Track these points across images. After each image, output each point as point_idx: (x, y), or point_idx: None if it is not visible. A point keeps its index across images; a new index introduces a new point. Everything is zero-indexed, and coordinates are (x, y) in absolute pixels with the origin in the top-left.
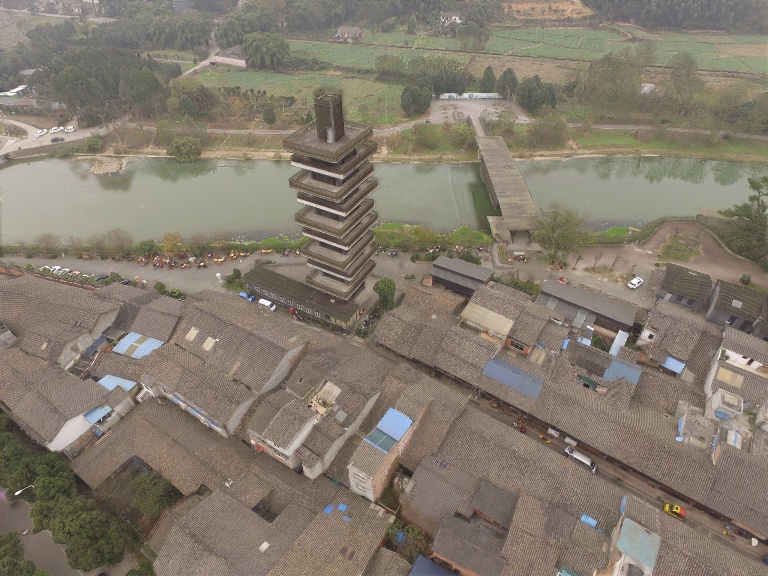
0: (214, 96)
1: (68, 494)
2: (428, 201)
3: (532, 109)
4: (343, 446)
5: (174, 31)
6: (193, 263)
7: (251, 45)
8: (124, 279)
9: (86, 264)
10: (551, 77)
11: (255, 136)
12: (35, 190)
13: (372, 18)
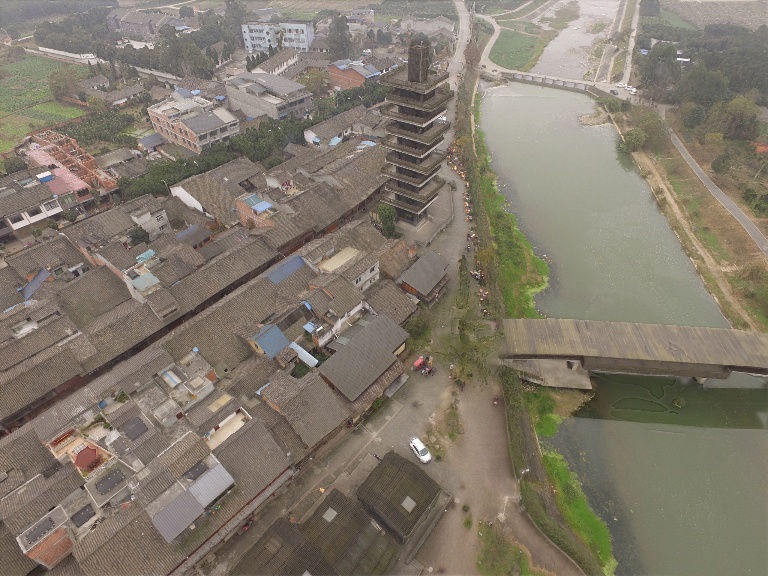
0: (752, 131)
1: (279, 141)
2: (607, 300)
3: None
4: (272, 208)
5: None
6: (453, 160)
7: None
8: None
9: None
10: None
11: (688, 171)
12: (546, 105)
13: None
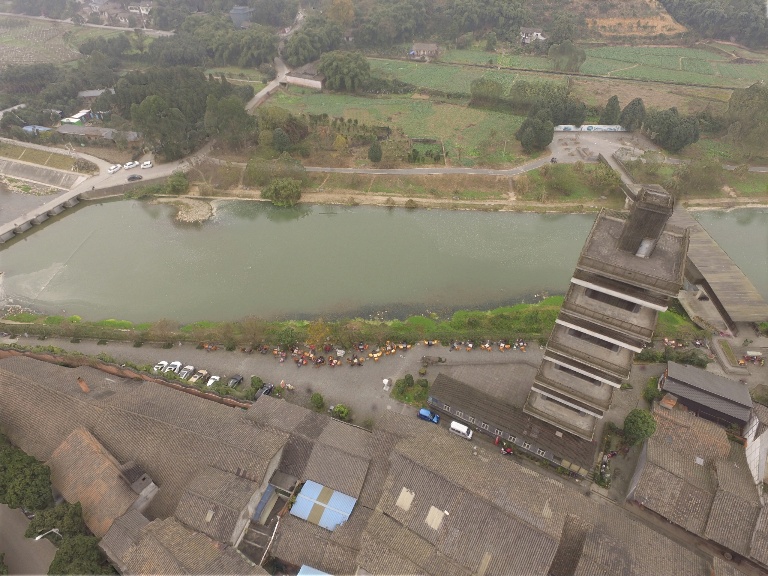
0: (303, 126)
1: None
2: None
3: (670, 146)
4: None
5: (238, 47)
6: (343, 358)
7: (330, 65)
8: (265, 384)
9: (210, 357)
10: (669, 105)
11: (359, 176)
12: (119, 242)
13: (443, 33)
